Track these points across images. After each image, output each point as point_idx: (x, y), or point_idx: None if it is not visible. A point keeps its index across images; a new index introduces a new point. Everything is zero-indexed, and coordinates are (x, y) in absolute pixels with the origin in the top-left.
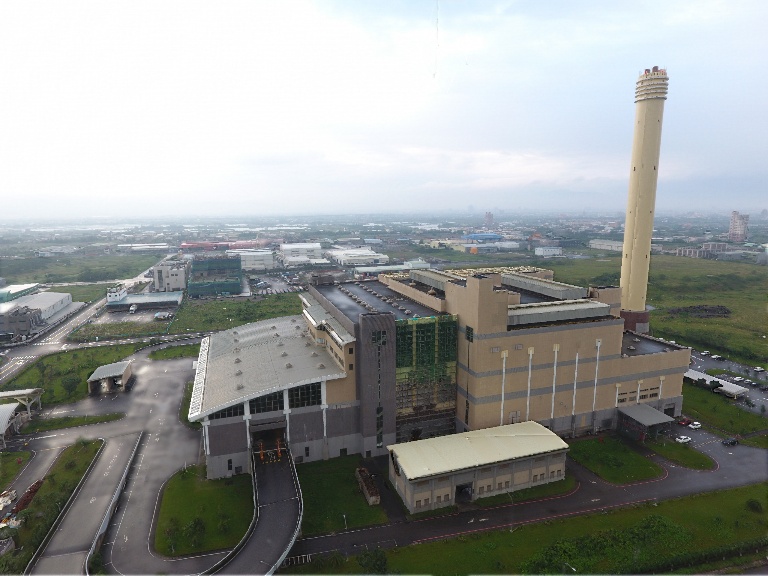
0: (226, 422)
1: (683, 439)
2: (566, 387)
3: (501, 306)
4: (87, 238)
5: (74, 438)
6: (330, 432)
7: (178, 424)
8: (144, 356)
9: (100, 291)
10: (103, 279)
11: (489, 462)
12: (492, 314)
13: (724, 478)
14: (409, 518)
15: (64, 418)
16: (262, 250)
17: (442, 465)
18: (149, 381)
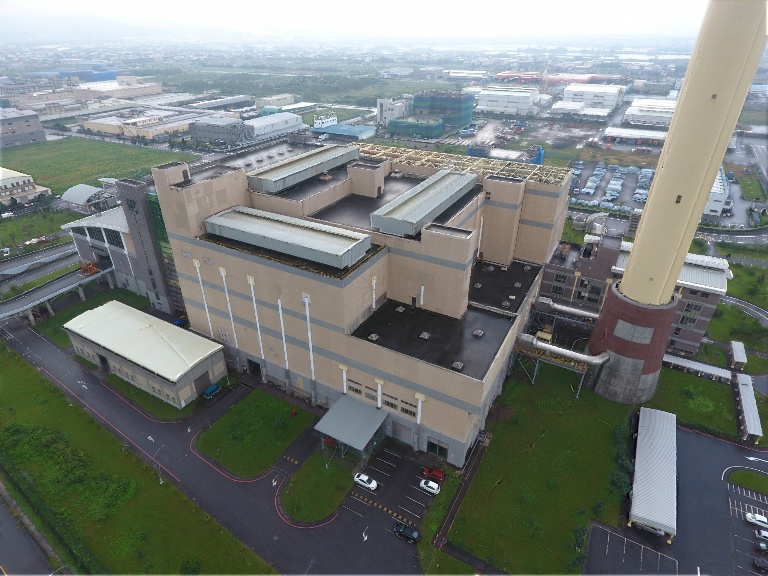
0: (81, 237)
1: (358, 479)
2: (273, 333)
3: (180, 207)
4: (436, 61)
5: None
6: (136, 275)
7: None
8: None
9: (344, 117)
10: (369, 105)
11: (110, 349)
12: (174, 213)
13: (272, 536)
14: (72, 355)
15: None
16: (521, 90)
17: (90, 331)
18: None
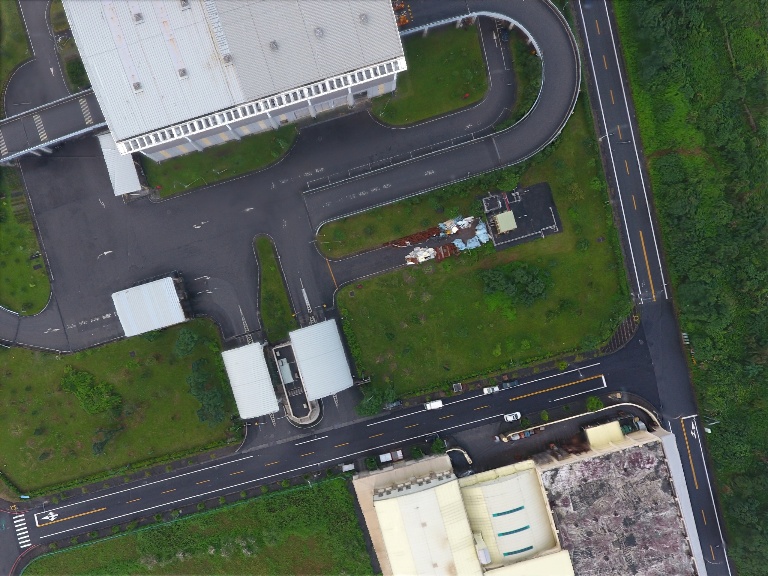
0: None
1: None
2: None
3: None
4: None
5: (312, 264)
6: None
7: (285, 161)
8: (33, 321)
9: None
10: None
11: None
12: None
13: None
14: None
15: (270, 301)
16: None
17: None
18: (148, 259)
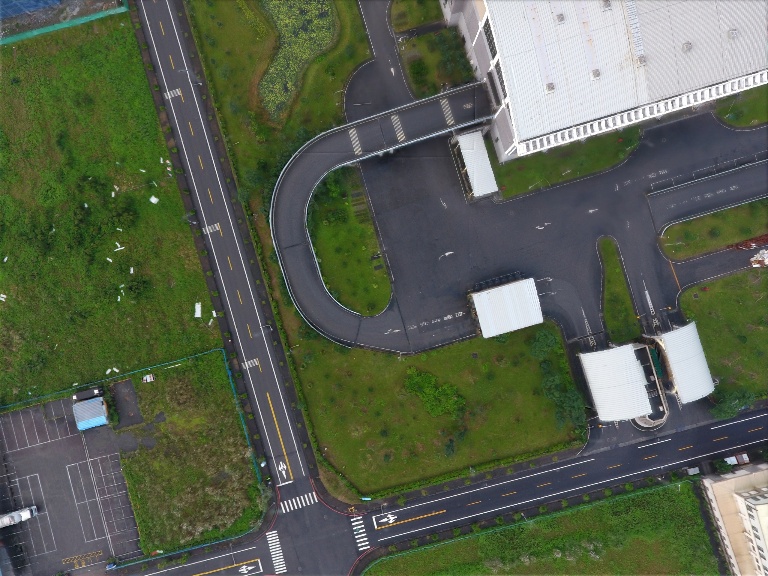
0: None
1: None
2: None
3: None
4: None
5: (655, 266)
6: None
7: (629, 163)
8: (375, 321)
9: None
10: None
11: None
12: None
13: None
14: None
15: None
16: None
17: None
18: (490, 260)
